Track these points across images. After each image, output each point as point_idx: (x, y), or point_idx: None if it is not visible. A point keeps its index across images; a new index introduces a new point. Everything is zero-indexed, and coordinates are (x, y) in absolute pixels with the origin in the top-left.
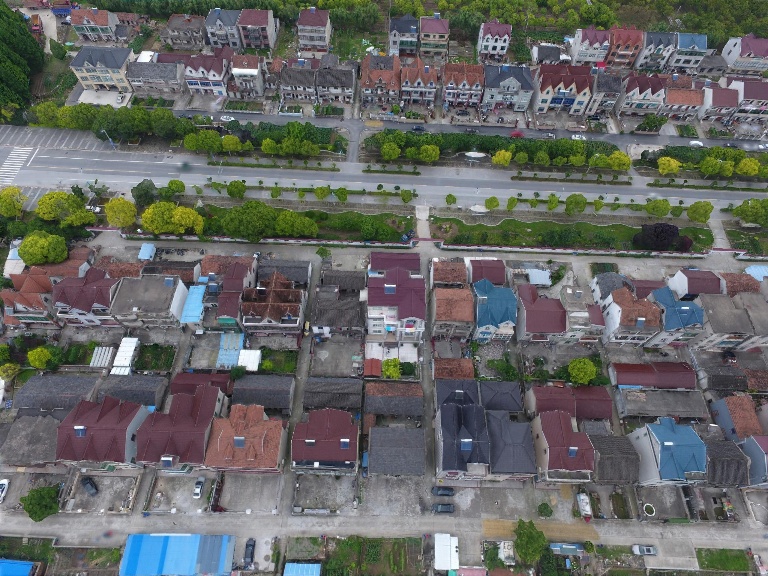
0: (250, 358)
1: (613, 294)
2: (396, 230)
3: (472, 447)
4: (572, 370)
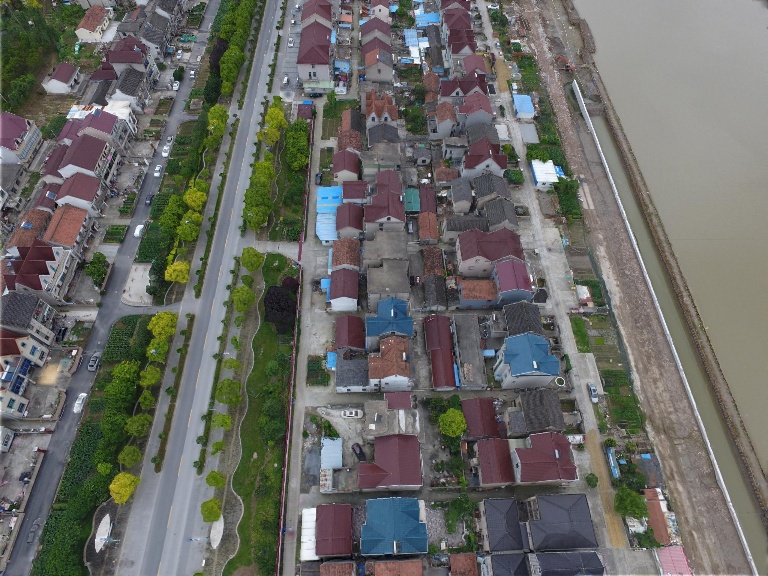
0: None
1: (373, 378)
2: None
3: (589, 574)
4: (456, 434)
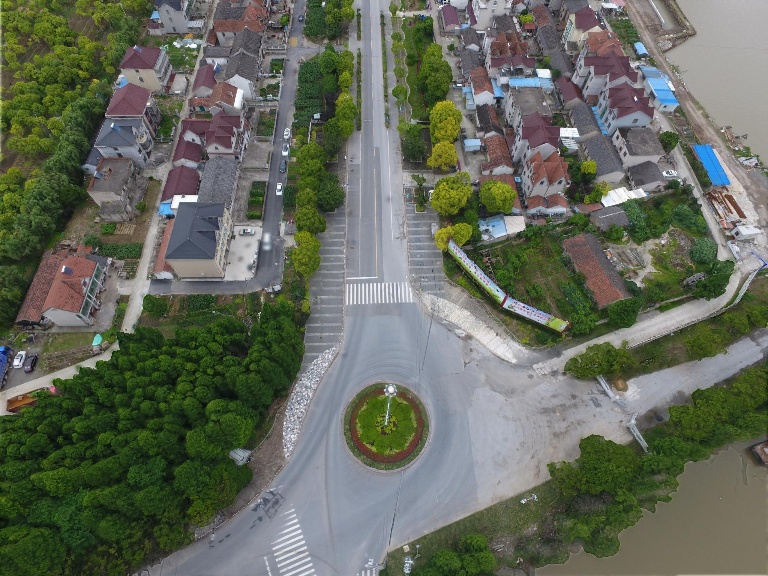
0: (543, 73)
1: None
2: (418, 23)
3: None
4: None
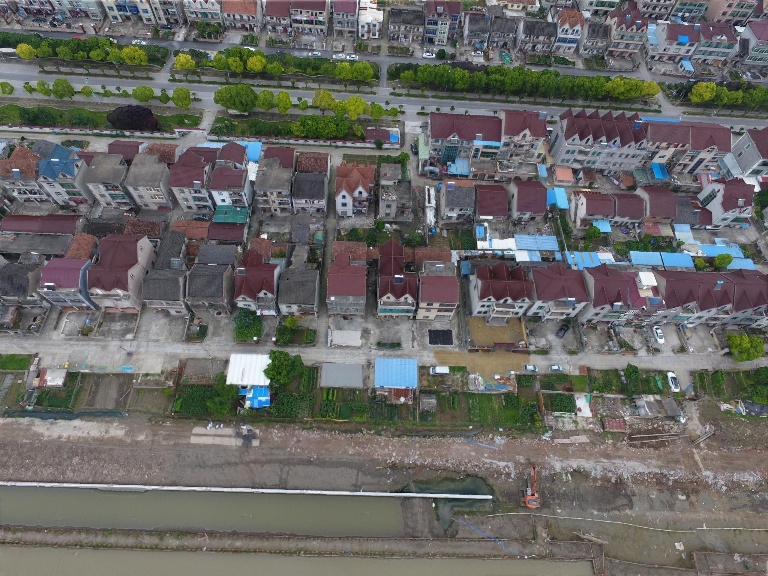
0: None
1: None
2: None
3: None
4: None
